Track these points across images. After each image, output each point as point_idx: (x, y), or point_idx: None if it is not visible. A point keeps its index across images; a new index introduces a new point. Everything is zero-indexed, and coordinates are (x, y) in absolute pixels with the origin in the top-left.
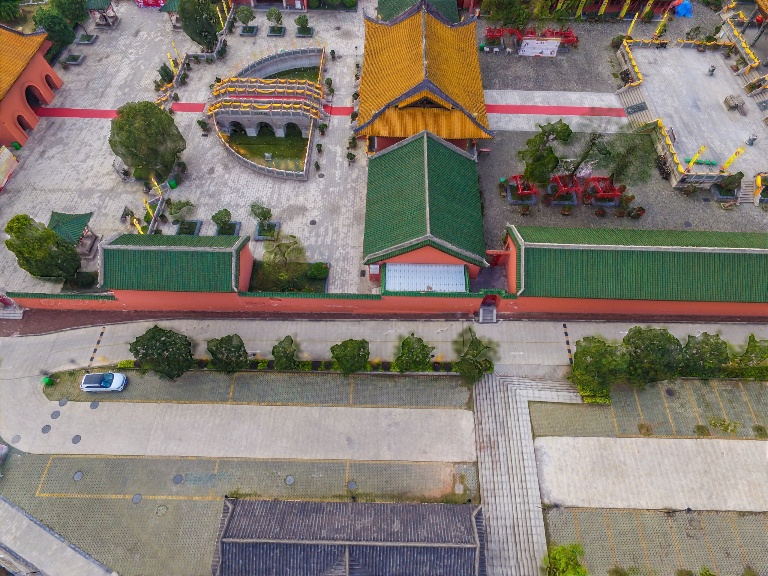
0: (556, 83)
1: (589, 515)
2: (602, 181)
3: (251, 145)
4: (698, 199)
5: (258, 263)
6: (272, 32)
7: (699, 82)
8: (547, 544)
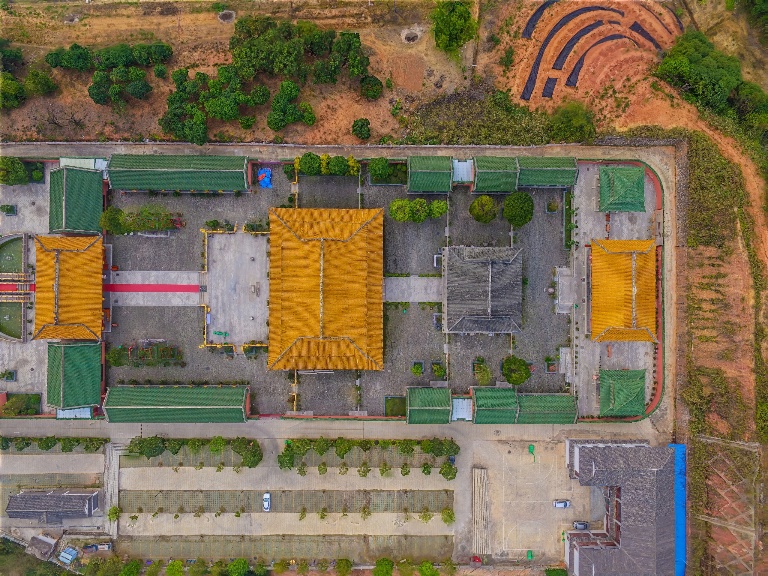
0: (165, 263)
1: (134, 493)
2: (165, 350)
3: None
4: (218, 353)
5: (9, 395)
6: None
7: (244, 267)
8: (118, 502)
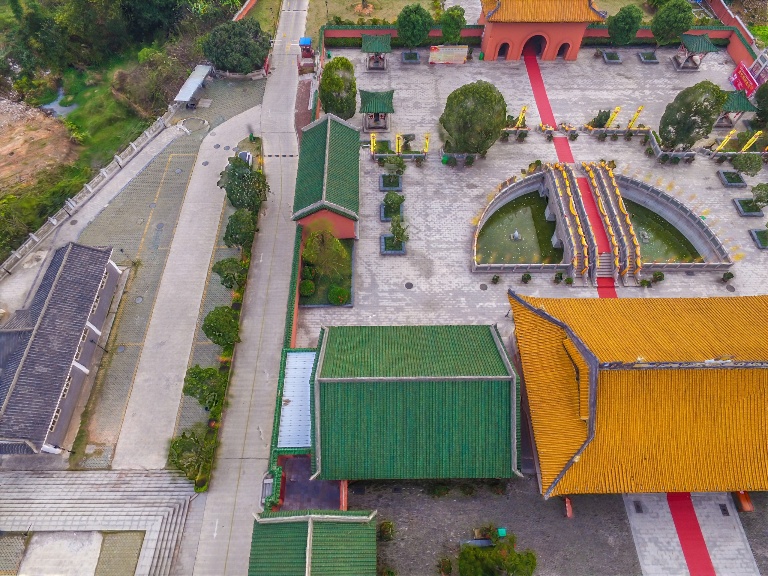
0: None
1: None
2: None
3: (533, 218)
4: None
5: (350, 242)
6: (742, 202)
7: None
8: None
